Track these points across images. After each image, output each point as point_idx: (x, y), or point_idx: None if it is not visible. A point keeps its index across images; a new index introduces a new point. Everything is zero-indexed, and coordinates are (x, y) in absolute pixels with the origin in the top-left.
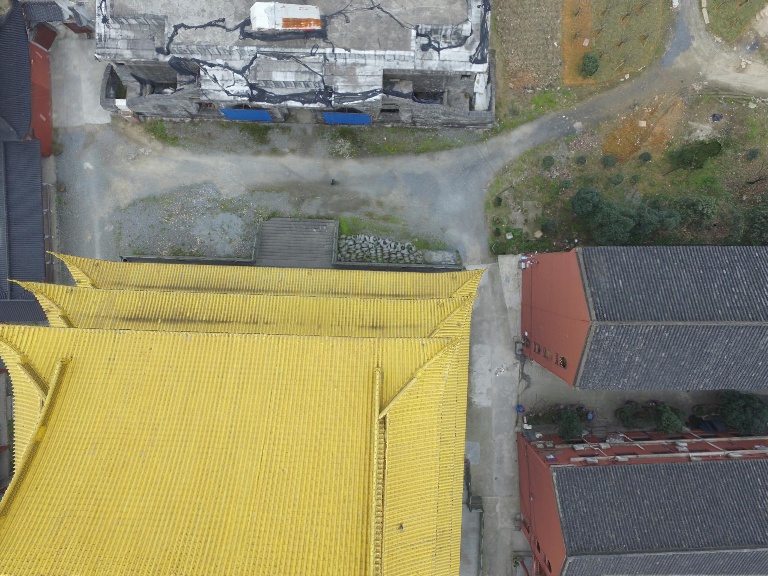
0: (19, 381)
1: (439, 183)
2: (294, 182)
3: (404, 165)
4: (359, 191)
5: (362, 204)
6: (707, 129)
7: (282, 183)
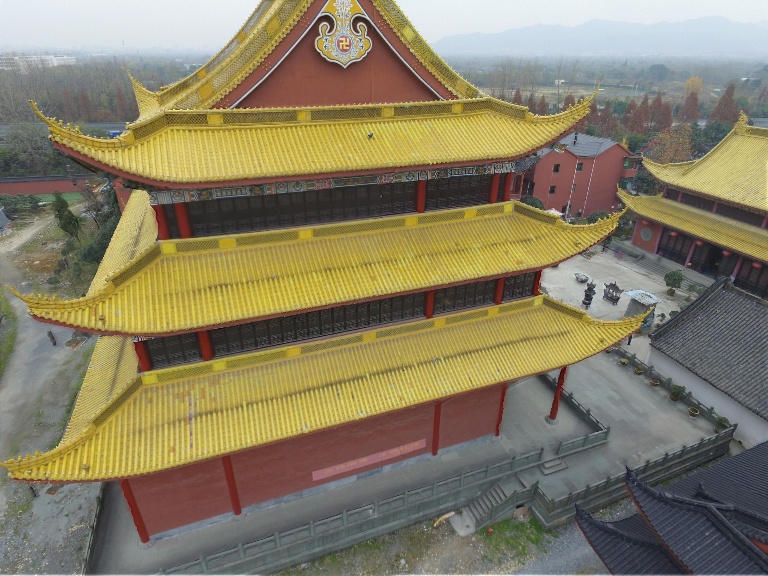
0: (170, 172)
1: (54, 332)
2: (7, 439)
3: (22, 357)
4: (44, 380)
5: (63, 375)
6: (52, 245)
7: (4, 451)
